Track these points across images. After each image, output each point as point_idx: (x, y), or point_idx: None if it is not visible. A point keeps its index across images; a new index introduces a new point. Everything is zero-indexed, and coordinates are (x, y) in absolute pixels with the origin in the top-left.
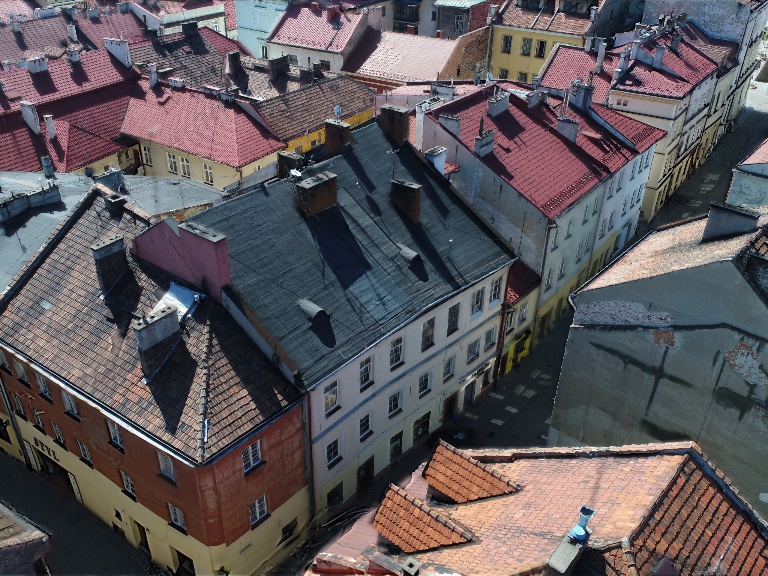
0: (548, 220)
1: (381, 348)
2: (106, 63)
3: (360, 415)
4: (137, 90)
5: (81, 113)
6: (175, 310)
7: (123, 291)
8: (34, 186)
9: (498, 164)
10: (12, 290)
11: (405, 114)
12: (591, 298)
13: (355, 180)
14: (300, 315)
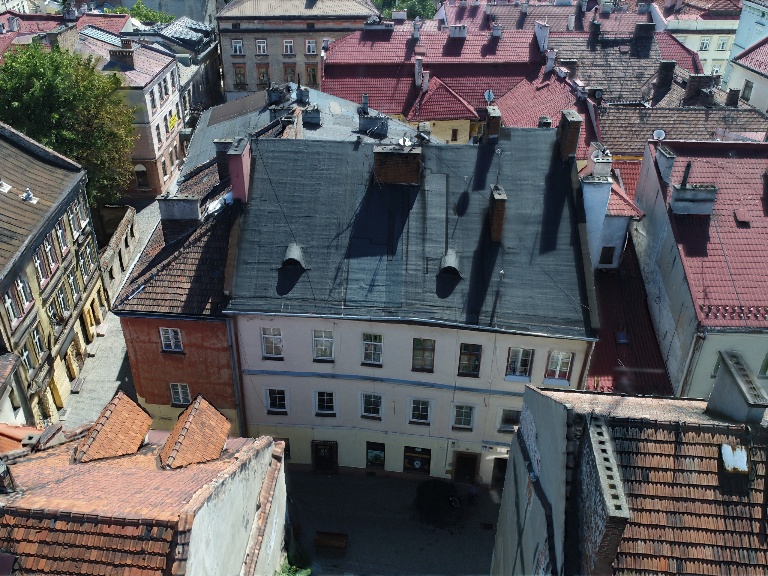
0: (697, 324)
1: (345, 330)
2: (524, 43)
3: (315, 386)
4: (535, 73)
5: (468, 79)
6: (194, 199)
7: (225, 184)
8: (334, 112)
9: (699, 232)
10: (210, 163)
11: (574, 124)
12: (526, 398)
13: (468, 173)
14: (281, 255)
